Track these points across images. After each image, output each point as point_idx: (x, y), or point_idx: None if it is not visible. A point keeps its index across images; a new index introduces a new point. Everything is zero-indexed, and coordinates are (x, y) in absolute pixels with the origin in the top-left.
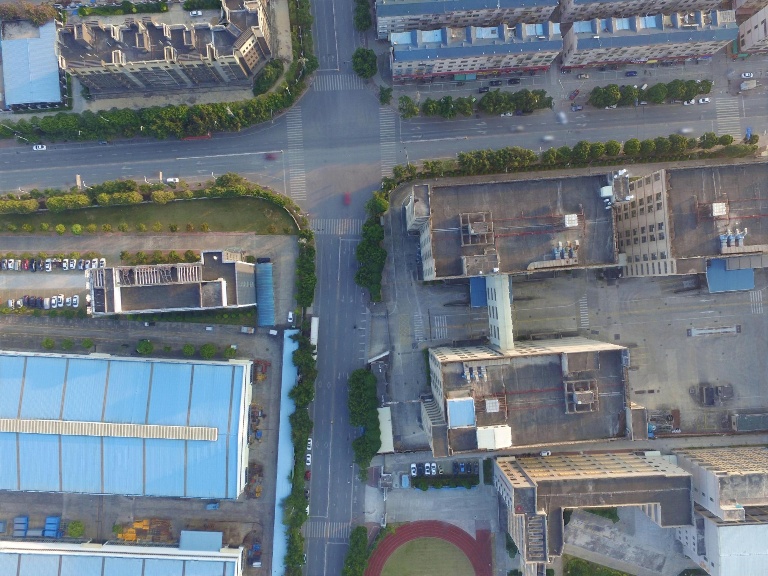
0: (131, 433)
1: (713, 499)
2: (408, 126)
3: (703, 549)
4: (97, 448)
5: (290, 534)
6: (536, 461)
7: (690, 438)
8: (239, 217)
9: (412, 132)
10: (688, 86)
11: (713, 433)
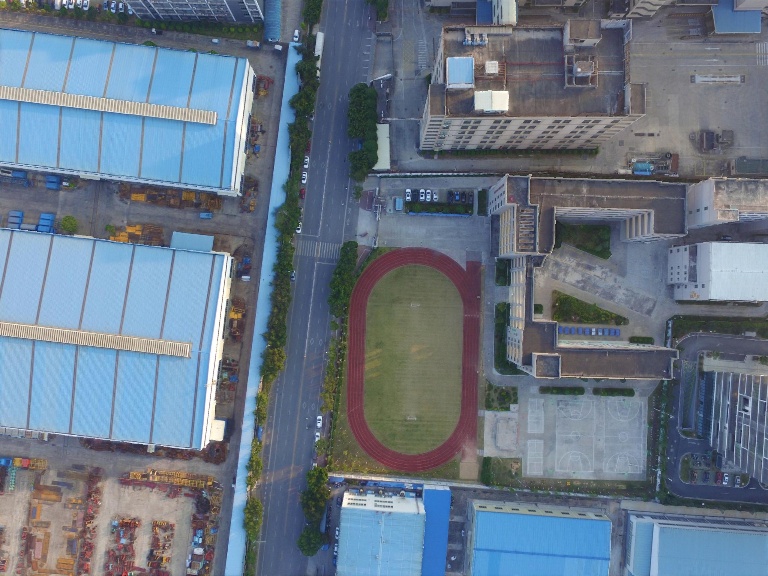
0: (131, 110)
1: (707, 206)
2: None
3: (694, 276)
4: (97, 124)
5: (281, 245)
6: None
7: None
8: None
9: None
10: None
11: None
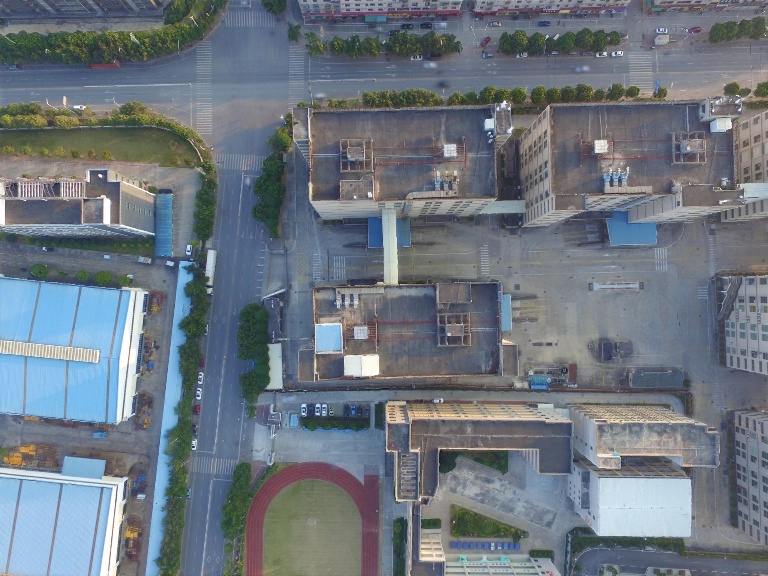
0: (13, 350)
1: (592, 447)
2: (317, 65)
3: (587, 503)
4: None
5: (174, 466)
6: (426, 406)
7: (587, 394)
8: (144, 148)
9: (321, 72)
10: (596, 35)
11: (610, 389)
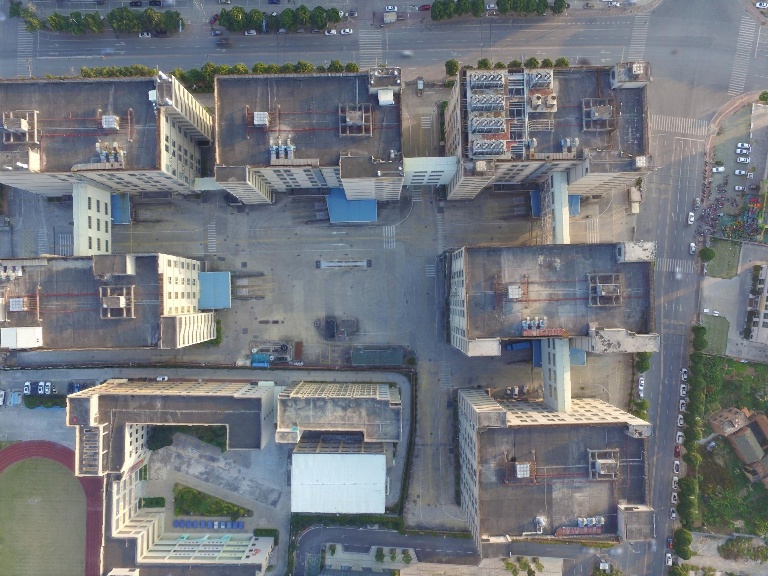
0: None
1: None
2: (46, 43)
3: None
4: None
5: None
6: (143, 384)
7: (313, 372)
8: None
9: (50, 49)
10: (312, 12)
11: (334, 367)
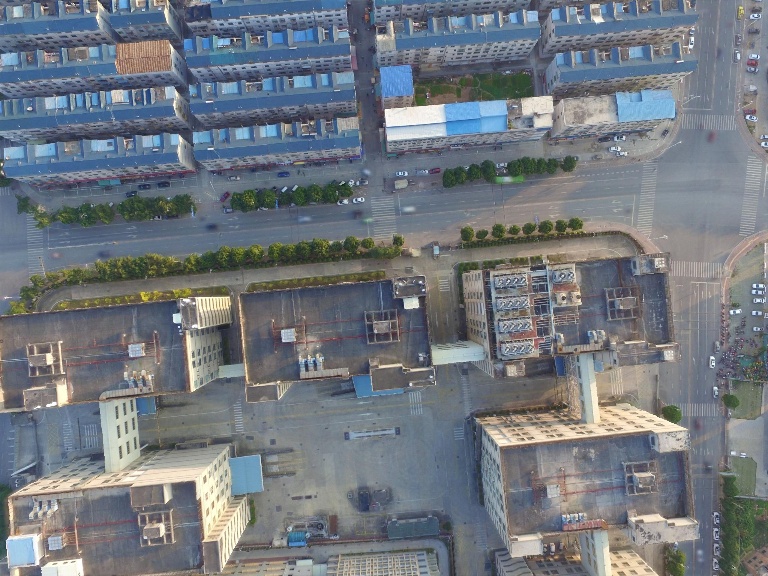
0: None
1: None
2: (56, 232)
3: None
4: None
5: None
6: None
7: (349, 544)
8: None
9: (60, 238)
10: (324, 191)
11: (371, 539)
